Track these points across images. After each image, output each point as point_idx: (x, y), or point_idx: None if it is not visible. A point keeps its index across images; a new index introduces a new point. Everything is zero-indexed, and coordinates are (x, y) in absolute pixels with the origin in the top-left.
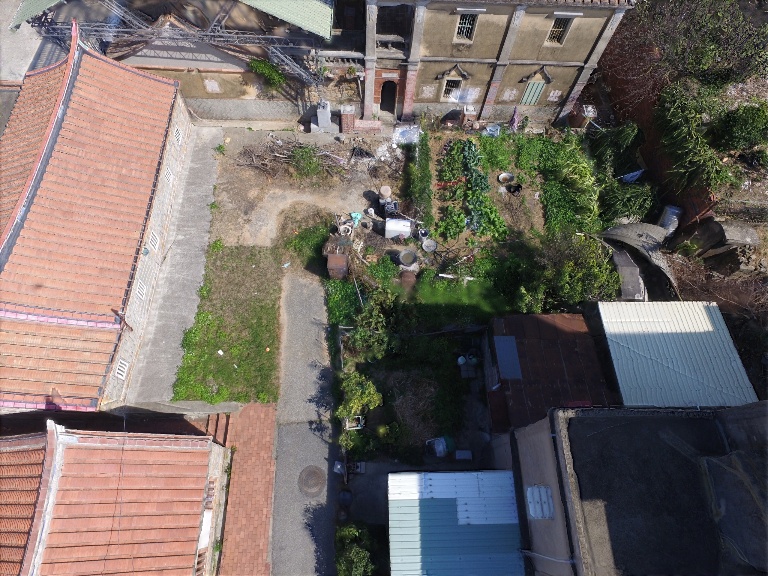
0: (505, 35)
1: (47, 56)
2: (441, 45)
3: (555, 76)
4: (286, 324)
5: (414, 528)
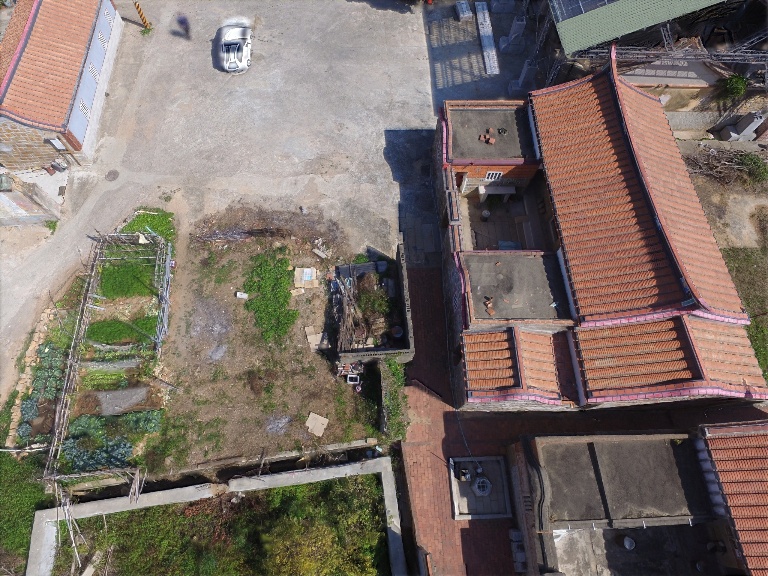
0: None
1: (442, 75)
2: None
3: None
4: None
5: None
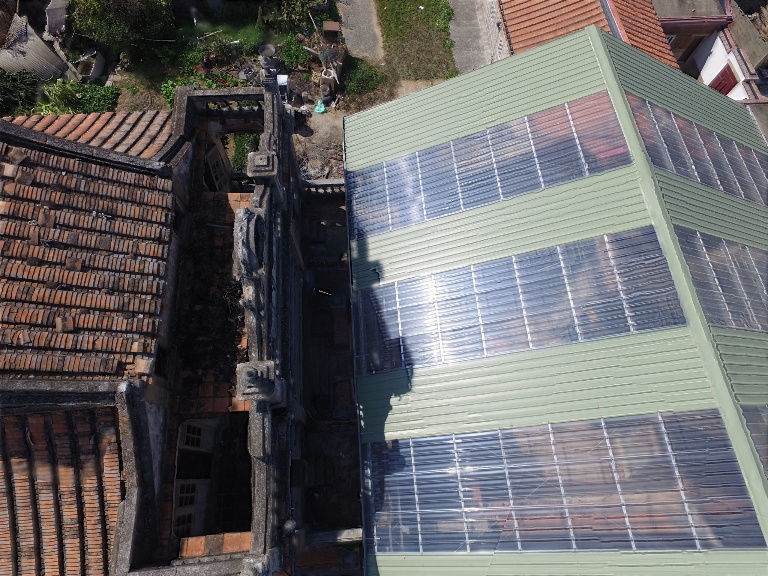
0: None
1: None
2: None
3: None
4: (375, 26)
5: None
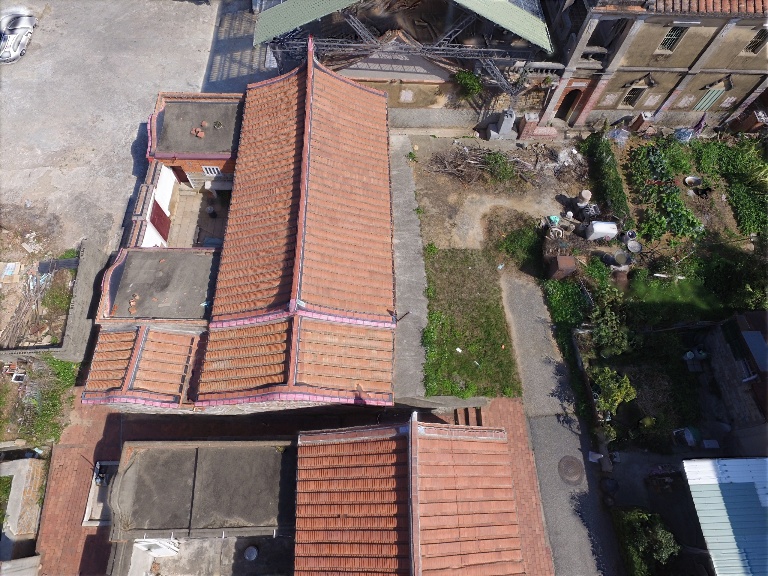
0: (707, 46)
1: (218, 68)
2: (641, 56)
3: (737, 83)
4: (513, 323)
5: (722, 510)
